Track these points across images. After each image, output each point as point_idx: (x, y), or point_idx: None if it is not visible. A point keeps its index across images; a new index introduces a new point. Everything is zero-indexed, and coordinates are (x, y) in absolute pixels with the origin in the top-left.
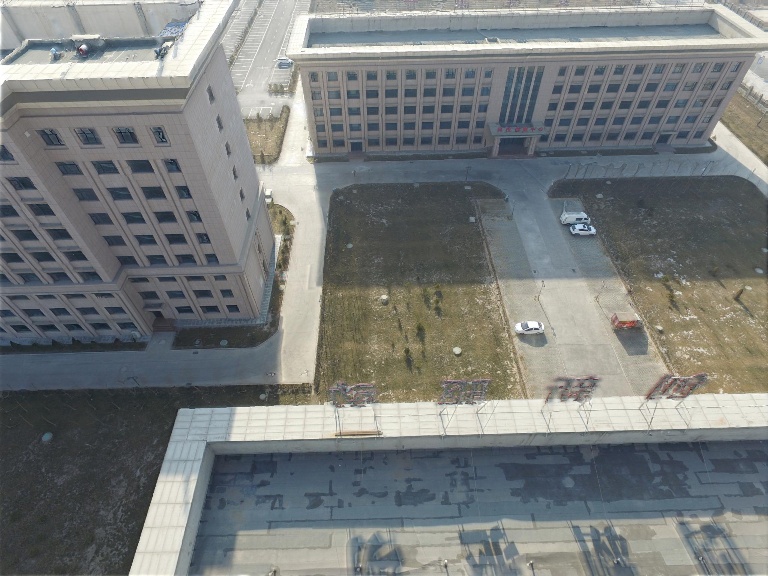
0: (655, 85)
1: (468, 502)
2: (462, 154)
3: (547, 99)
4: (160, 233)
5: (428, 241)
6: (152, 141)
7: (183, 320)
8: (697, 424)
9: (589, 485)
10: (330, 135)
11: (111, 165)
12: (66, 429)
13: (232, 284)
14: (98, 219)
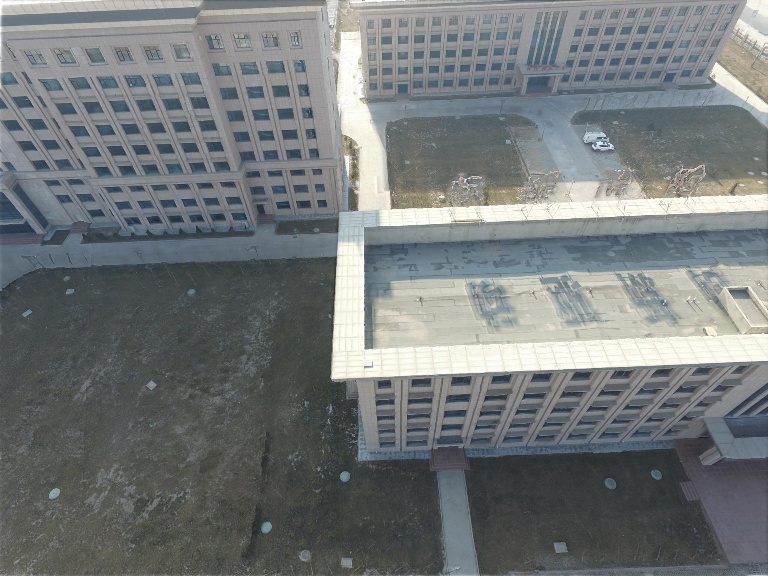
0: (662, 27)
1: (543, 265)
2: (494, 94)
3: (569, 41)
4: (279, 129)
5: (473, 158)
6: (289, 44)
7: (280, 215)
8: (700, 211)
9: (625, 255)
10: (381, 78)
11: (252, 67)
12: (204, 287)
13: (326, 178)
14: (232, 117)
